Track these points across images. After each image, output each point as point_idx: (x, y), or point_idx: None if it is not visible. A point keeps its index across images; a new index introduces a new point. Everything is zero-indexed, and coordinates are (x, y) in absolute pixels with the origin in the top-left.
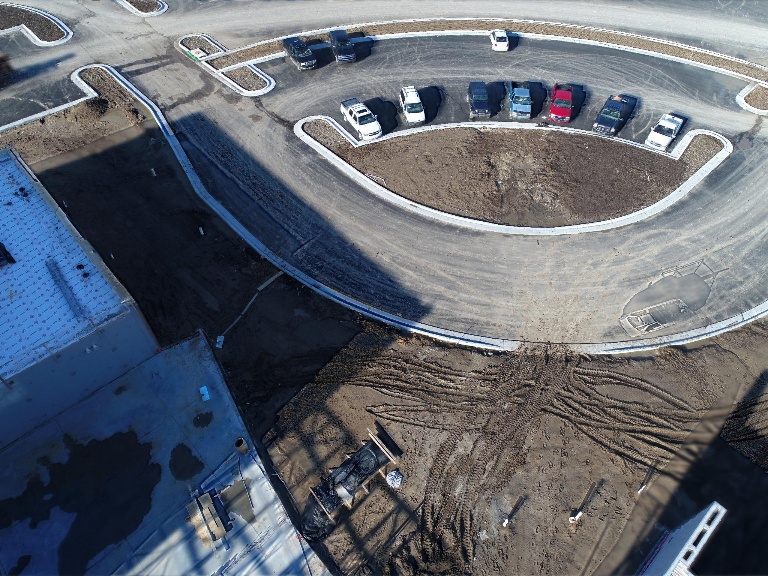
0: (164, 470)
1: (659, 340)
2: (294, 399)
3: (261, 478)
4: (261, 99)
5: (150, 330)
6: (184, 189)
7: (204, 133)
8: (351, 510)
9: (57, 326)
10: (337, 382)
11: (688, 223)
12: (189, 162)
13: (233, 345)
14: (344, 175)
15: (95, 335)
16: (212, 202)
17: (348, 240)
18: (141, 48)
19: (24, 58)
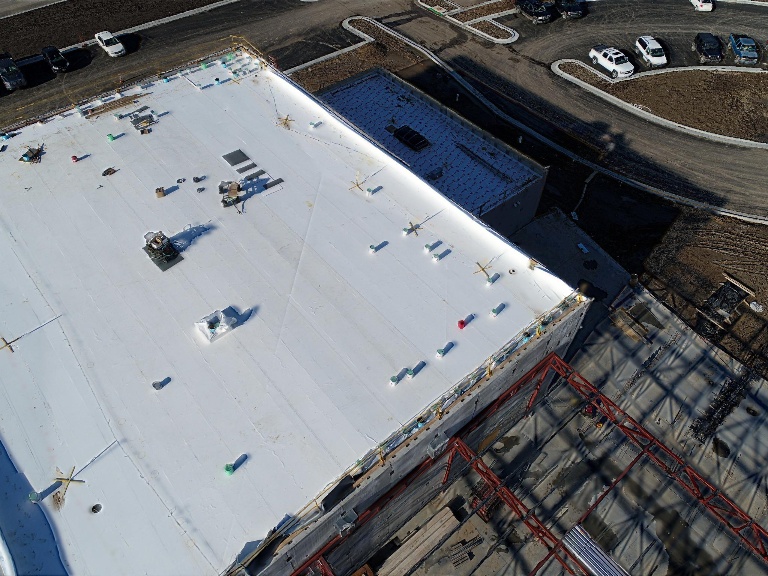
0: None
1: None
2: (652, 255)
3: (655, 302)
4: (512, 46)
5: None
6: (484, 111)
7: (478, 70)
8: (731, 325)
9: (493, 186)
10: (681, 245)
11: None
12: (478, 92)
13: (586, 218)
14: (612, 104)
15: (523, 193)
16: (513, 121)
17: (638, 151)
18: (389, 4)
19: (295, 10)
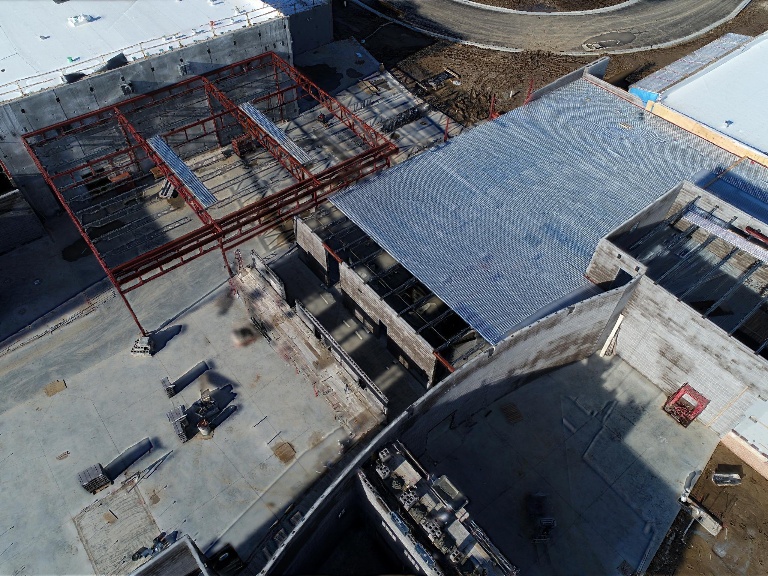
0: (344, 75)
1: (602, 52)
2: (405, 60)
3: (392, 79)
4: None
5: (332, 23)
6: None
7: None
8: (436, 90)
9: None
10: (427, 55)
11: (631, 14)
12: None
13: (370, 43)
14: None
15: (312, 11)
16: None
17: (428, 13)
18: None
19: None
